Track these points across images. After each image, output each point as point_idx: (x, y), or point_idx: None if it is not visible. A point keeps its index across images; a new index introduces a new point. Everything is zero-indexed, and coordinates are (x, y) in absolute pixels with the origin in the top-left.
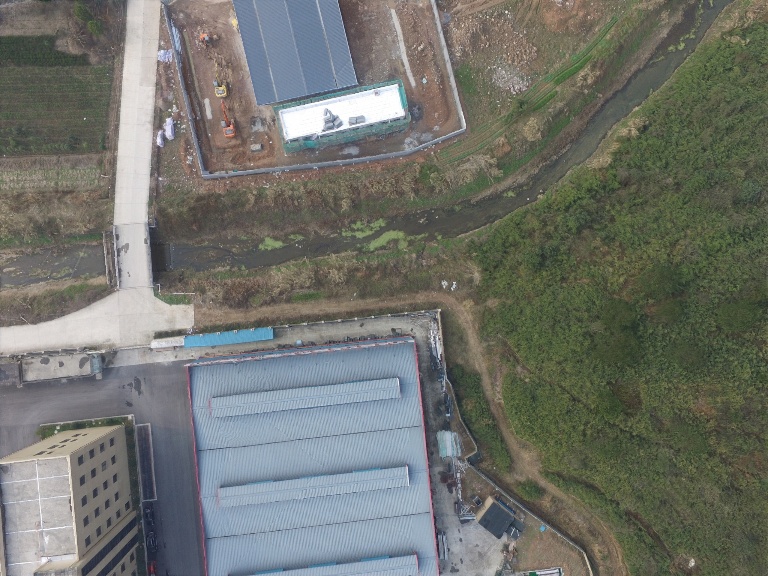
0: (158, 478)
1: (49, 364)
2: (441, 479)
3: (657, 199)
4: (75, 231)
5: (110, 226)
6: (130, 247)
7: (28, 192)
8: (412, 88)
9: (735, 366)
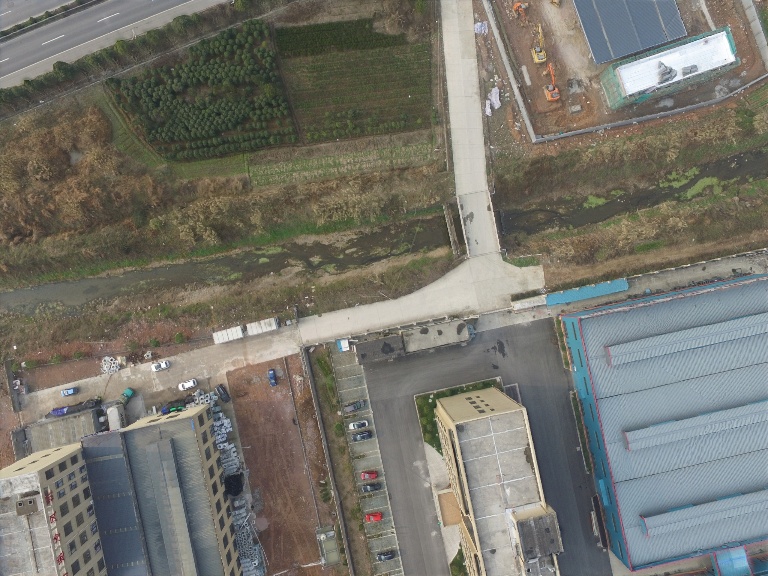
0: None
1: (428, 333)
2: None
3: None
4: (418, 206)
5: (452, 197)
6: (475, 216)
7: (366, 173)
8: None
9: None
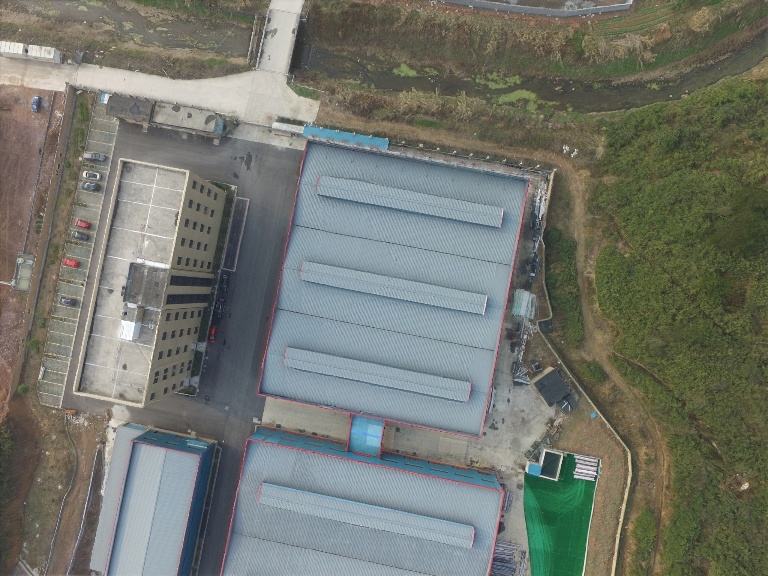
0: (242, 251)
1: (179, 112)
2: (507, 335)
3: None
4: (232, 6)
5: (265, 9)
6: (278, 33)
7: None
8: None
9: None
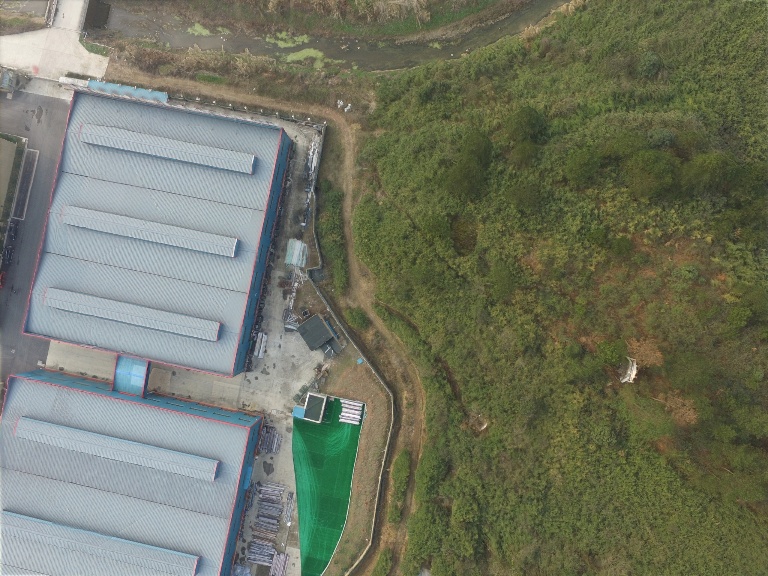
0: (31, 201)
1: None
2: (279, 283)
3: (564, 67)
4: None
5: None
6: None
7: None
8: None
9: (568, 219)
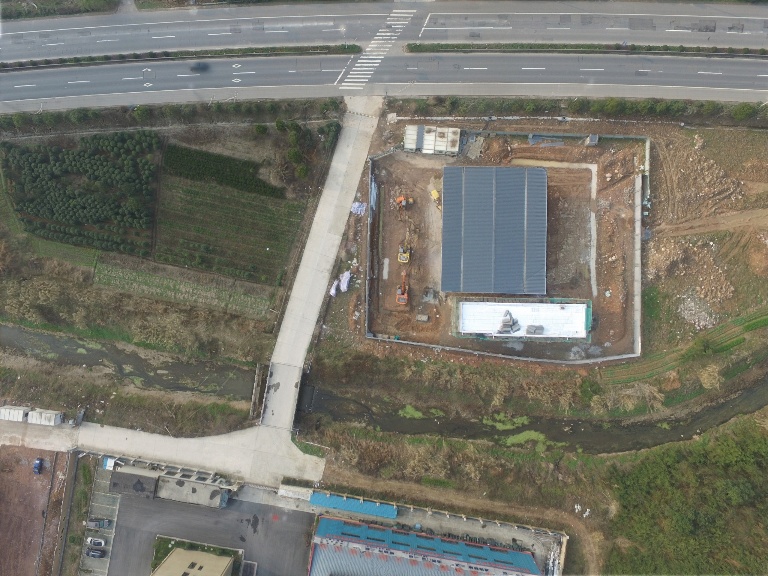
0: None
1: (183, 487)
2: None
3: None
4: (233, 357)
5: (267, 361)
6: (280, 387)
7: (199, 307)
8: (593, 297)
9: None
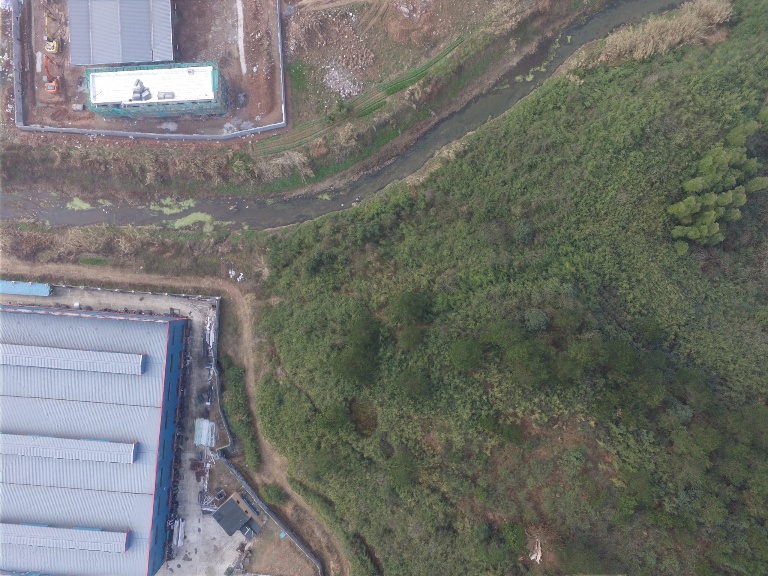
0: None
1: None
2: (191, 466)
3: (448, 225)
4: None
5: None
6: None
7: None
8: (242, 74)
9: (459, 405)
